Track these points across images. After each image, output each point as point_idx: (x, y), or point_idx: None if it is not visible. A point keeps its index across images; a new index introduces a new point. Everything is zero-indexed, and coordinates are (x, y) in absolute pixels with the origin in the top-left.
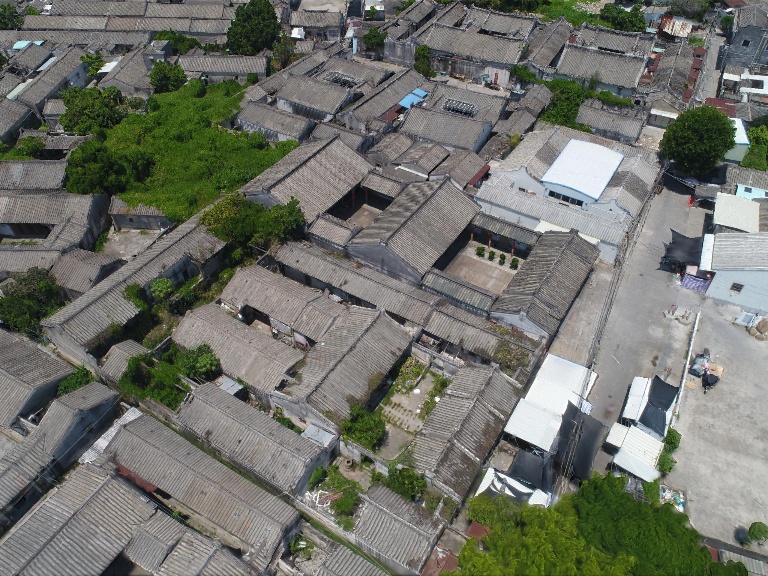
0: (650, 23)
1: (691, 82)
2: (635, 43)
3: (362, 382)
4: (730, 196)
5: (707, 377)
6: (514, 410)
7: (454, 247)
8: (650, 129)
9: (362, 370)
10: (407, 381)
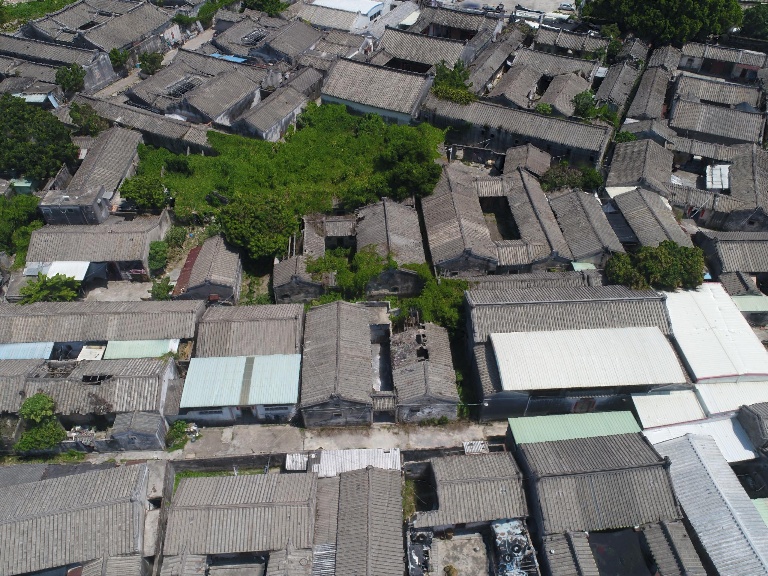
0: None
1: None
2: None
3: None
4: None
5: (498, 8)
6: None
7: None
8: None
9: None
10: None
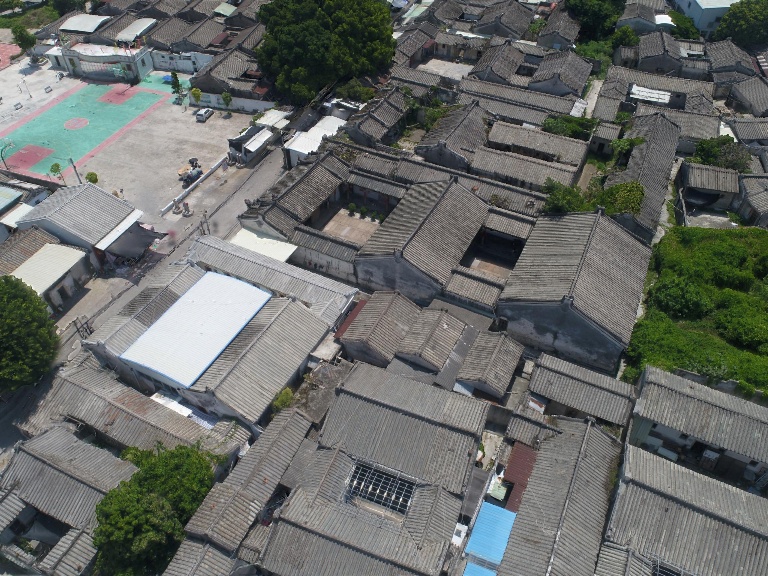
0: None
1: None
2: None
3: None
4: None
5: None
6: None
7: None
8: None
9: None
10: None
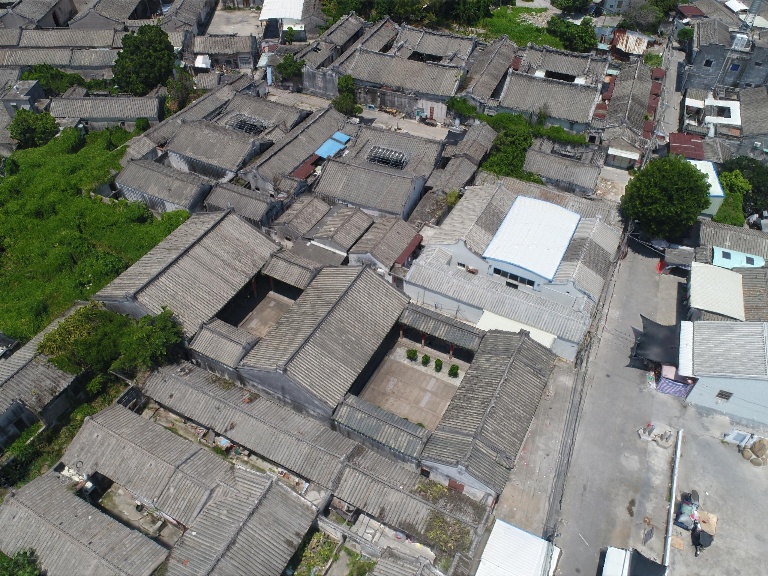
0: (602, 38)
1: (651, 111)
2: (587, 66)
3: None
4: (707, 267)
5: (698, 533)
6: None
7: (379, 349)
8: (608, 171)
9: None
10: (313, 569)
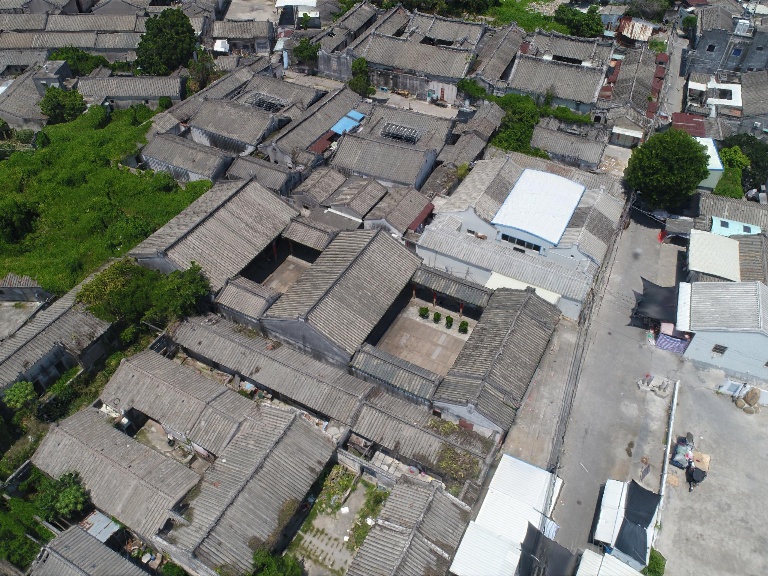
0: (608, 25)
1: (655, 93)
2: (593, 50)
3: (270, 516)
4: (705, 234)
5: (692, 470)
6: (462, 539)
7: (393, 307)
8: (613, 149)
9: (271, 498)
10: (333, 497)
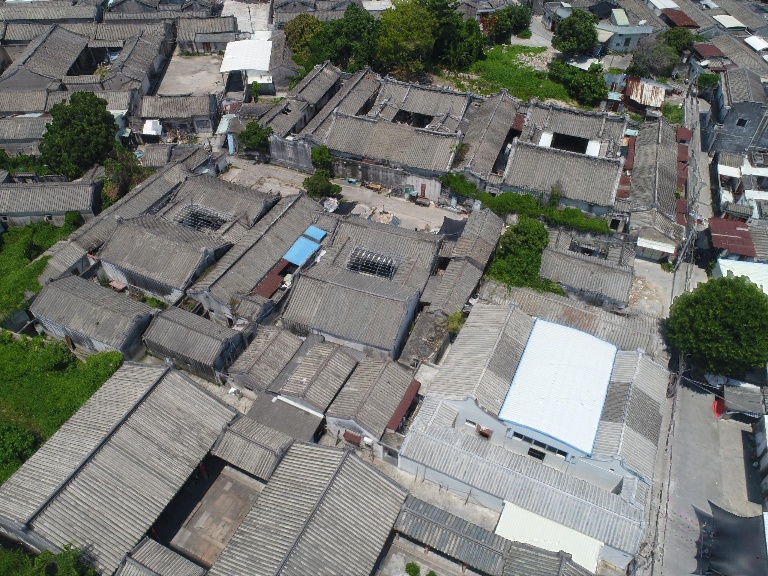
0: (612, 86)
1: (681, 185)
2: (601, 127)
3: None
4: None
5: None
6: None
7: None
8: (637, 264)
9: None
10: None
